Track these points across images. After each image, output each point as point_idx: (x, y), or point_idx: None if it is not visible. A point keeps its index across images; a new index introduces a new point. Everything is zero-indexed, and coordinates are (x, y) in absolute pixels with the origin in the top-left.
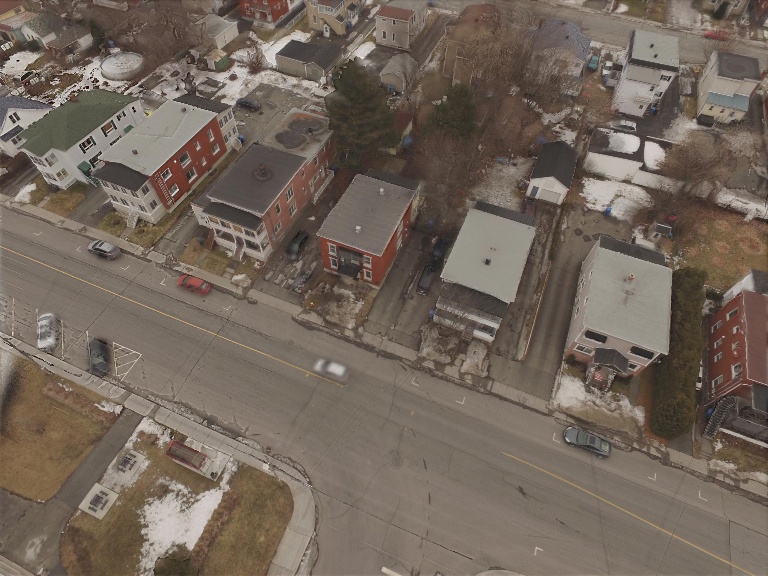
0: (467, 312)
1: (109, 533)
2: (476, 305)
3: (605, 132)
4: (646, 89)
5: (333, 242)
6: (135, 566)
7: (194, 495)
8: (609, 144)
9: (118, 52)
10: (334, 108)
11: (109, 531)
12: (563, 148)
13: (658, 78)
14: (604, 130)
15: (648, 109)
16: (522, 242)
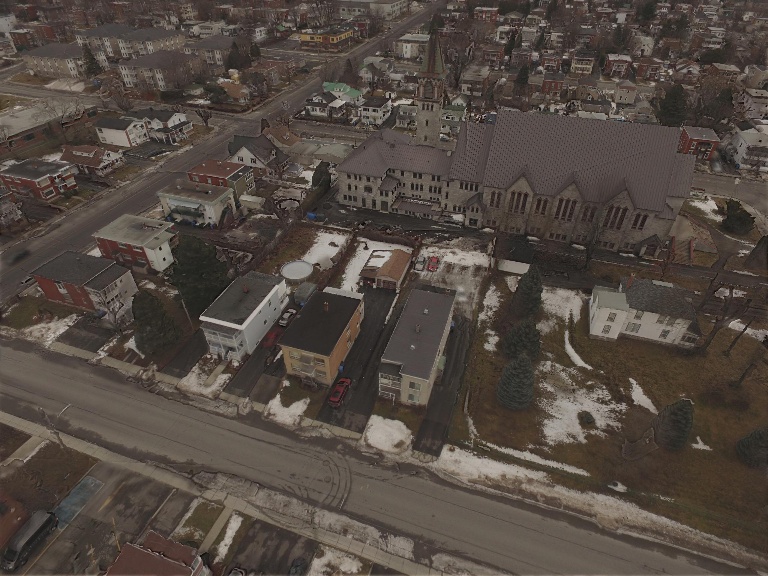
0: (760, 157)
1: (687, 207)
2: (766, 151)
3: (757, 120)
4: (764, 106)
5: (697, 140)
6: (704, 212)
7: (704, 201)
8: (763, 122)
9: (504, 107)
10: (671, 102)
11: (686, 207)
12: (748, 122)
13: (767, 102)
14: (756, 119)
15: (763, 117)
16: (767, 137)
